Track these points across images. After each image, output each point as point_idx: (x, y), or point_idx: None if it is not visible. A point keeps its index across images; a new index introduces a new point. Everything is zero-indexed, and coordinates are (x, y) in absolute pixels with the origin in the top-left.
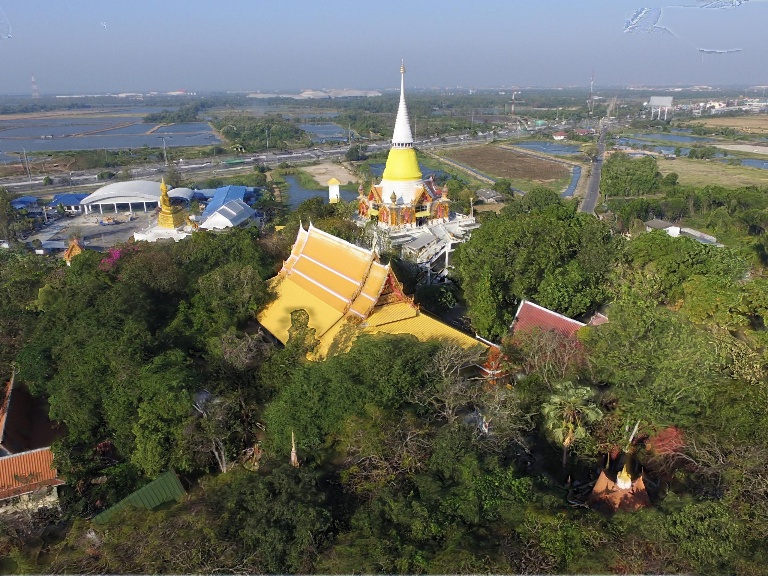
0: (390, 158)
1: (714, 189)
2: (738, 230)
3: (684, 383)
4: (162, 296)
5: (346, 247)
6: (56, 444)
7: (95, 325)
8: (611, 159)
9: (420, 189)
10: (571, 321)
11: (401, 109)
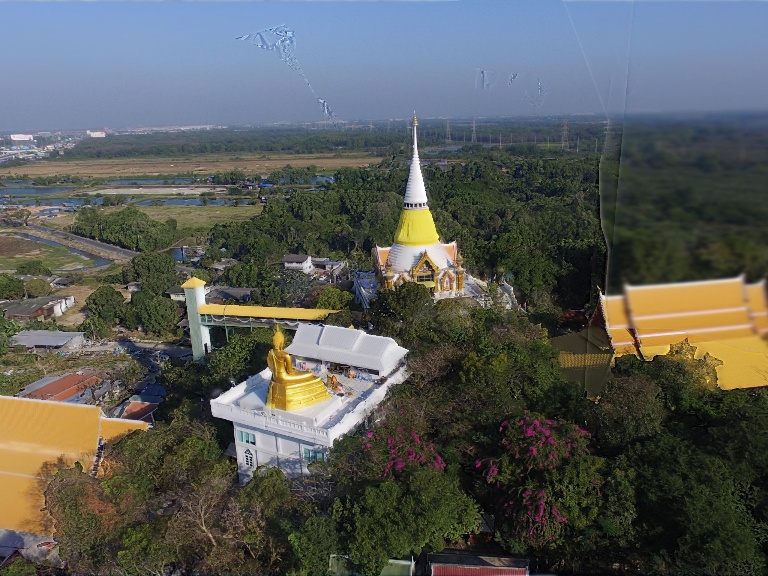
0: (420, 221)
1: (248, 224)
2: None
3: None
4: None
5: None
6: None
7: None
8: (80, 217)
9: (452, 246)
10: None
11: None
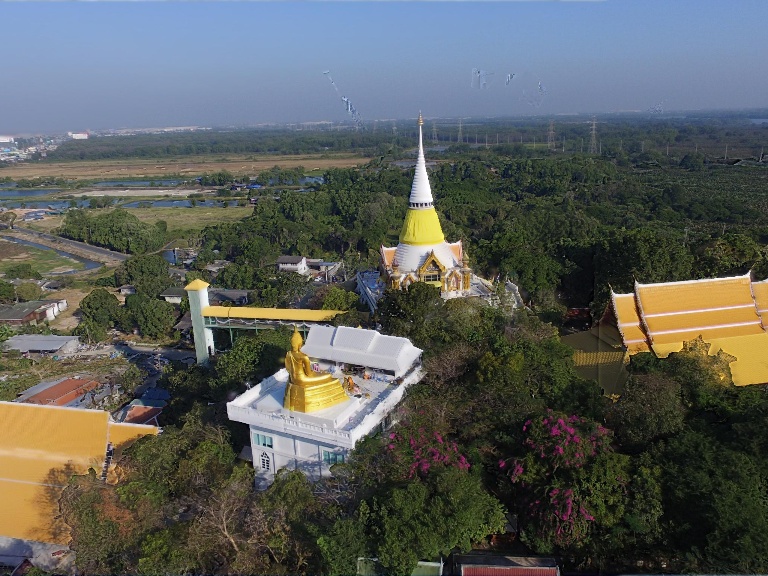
0: (426, 220)
1: (240, 225)
2: None
3: None
4: None
5: (709, 284)
6: None
7: None
8: (68, 219)
9: (457, 246)
10: None
11: None
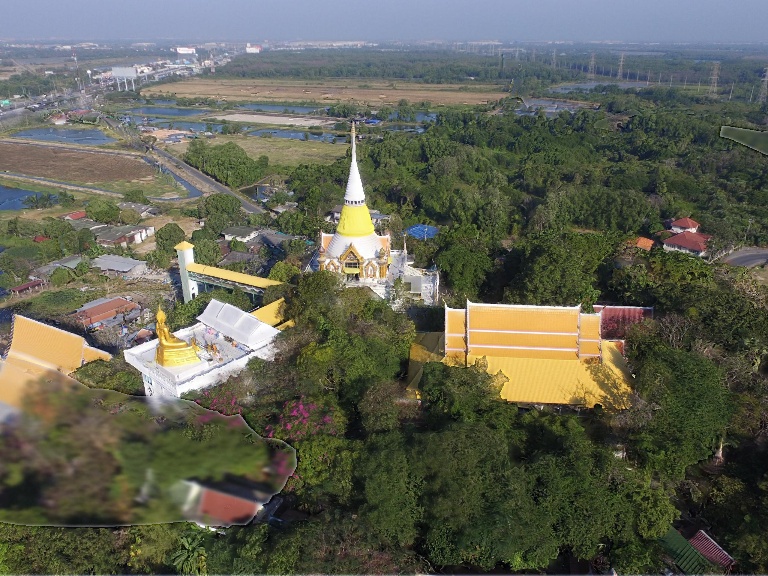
0: (354, 216)
1: (324, 168)
2: (380, 201)
3: (763, 318)
4: (414, 423)
5: (538, 310)
6: (645, 557)
7: (490, 470)
8: (191, 147)
9: (386, 239)
10: (623, 308)
11: (356, 168)
